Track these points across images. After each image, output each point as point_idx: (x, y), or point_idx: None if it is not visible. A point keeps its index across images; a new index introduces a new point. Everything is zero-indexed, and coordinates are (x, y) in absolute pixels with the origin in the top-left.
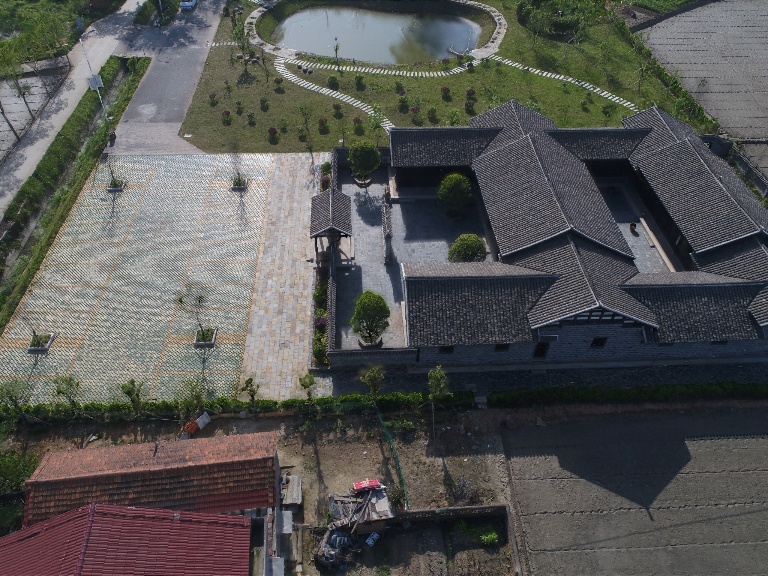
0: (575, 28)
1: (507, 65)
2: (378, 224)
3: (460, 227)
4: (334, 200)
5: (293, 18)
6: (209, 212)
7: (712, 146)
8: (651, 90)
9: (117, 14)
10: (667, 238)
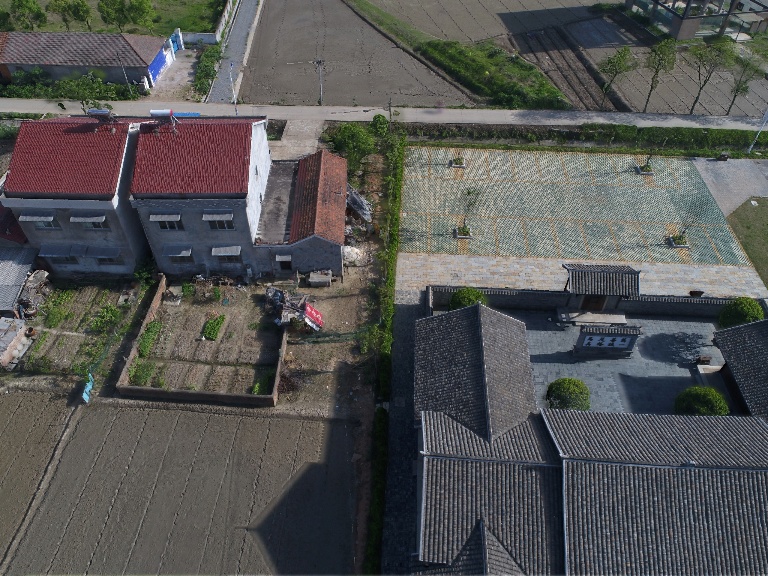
0: None
1: None
2: (642, 351)
3: None
4: (618, 274)
5: None
6: (625, 225)
7: None
8: None
9: None
10: None
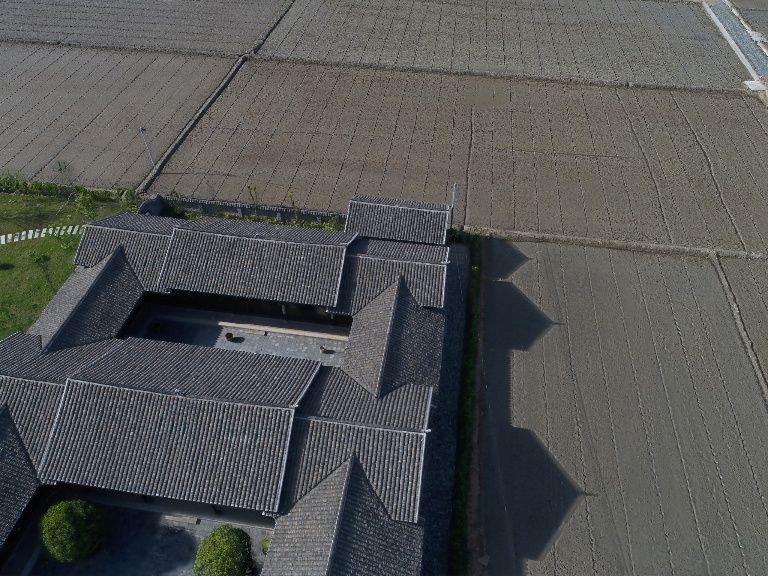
0: None
1: None
2: None
3: (123, 545)
4: None
5: None
6: None
7: (151, 212)
8: None
9: None
10: (264, 316)
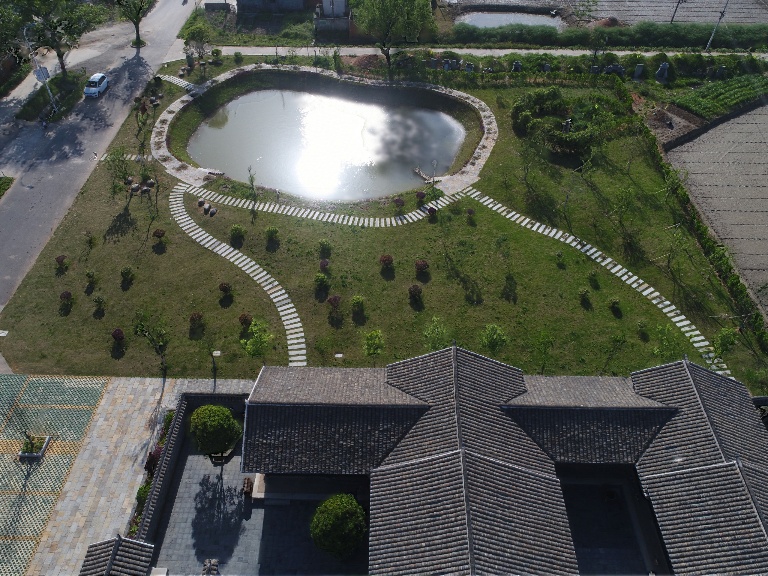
0: (587, 144)
1: (485, 208)
2: None
3: None
4: (111, 572)
5: (236, 101)
6: None
7: None
8: (685, 266)
9: (2, 102)
10: None
